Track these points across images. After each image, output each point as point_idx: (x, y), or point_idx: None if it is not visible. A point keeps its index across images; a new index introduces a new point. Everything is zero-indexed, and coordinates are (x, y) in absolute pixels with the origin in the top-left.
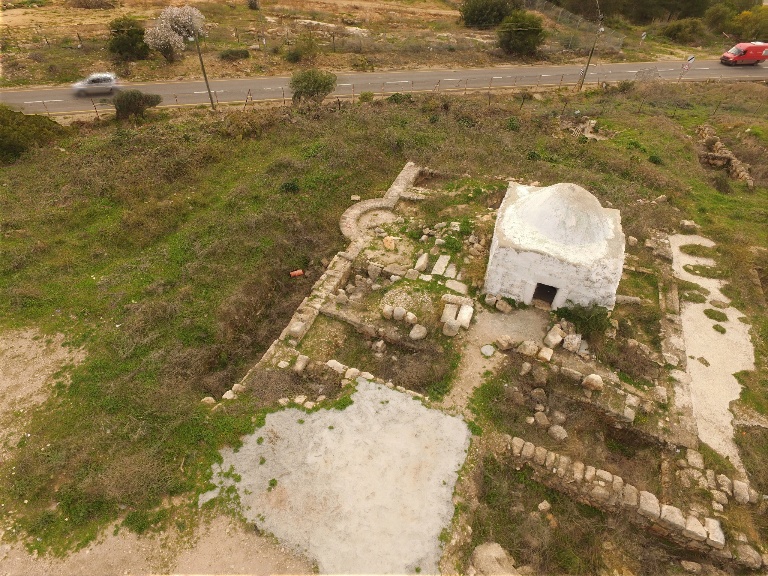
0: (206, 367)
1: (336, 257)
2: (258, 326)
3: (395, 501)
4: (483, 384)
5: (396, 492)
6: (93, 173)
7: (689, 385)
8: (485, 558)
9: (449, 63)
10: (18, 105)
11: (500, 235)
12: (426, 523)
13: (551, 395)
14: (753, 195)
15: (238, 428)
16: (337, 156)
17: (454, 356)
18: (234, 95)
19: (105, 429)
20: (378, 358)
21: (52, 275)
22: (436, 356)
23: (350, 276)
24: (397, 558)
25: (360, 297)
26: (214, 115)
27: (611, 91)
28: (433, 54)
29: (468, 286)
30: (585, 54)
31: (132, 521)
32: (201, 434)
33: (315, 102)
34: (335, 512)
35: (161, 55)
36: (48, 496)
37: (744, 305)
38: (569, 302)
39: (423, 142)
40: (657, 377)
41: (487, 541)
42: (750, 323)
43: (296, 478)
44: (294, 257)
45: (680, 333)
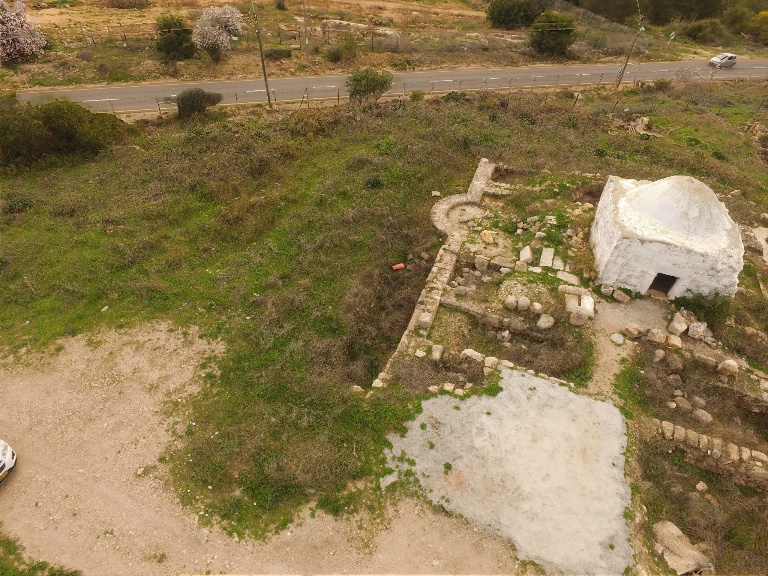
0: None
1: (441, 250)
2: (379, 318)
3: (571, 482)
4: (623, 370)
5: (570, 474)
6: (177, 170)
7: None
8: (667, 535)
9: (484, 62)
10: (85, 103)
11: (621, 226)
12: (607, 502)
13: (688, 381)
14: None
15: (400, 414)
16: (413, 153)
17: (587, 344)
18: (286, 94)
19: (270, 417)
20: (510, 347)
21: (167, 269)
22: None
23: (457, 269)
24: (589, 536)
25: (475, 289)
26: (271, 113)
27: (647, 90)
28: (468, 54)
29: (579, 277)
30: (613, 54)
31: (326, 504)
32: (365, 421)
33: (375, 100)
34: (516, 493)
35: (205, 54)
36: (230, 482)
37: None
38: (689, 291)
39: (489, 139)
40: None
41: (661, 520)
42: None
43: (469, 462)
44: (393, 251)
45: None
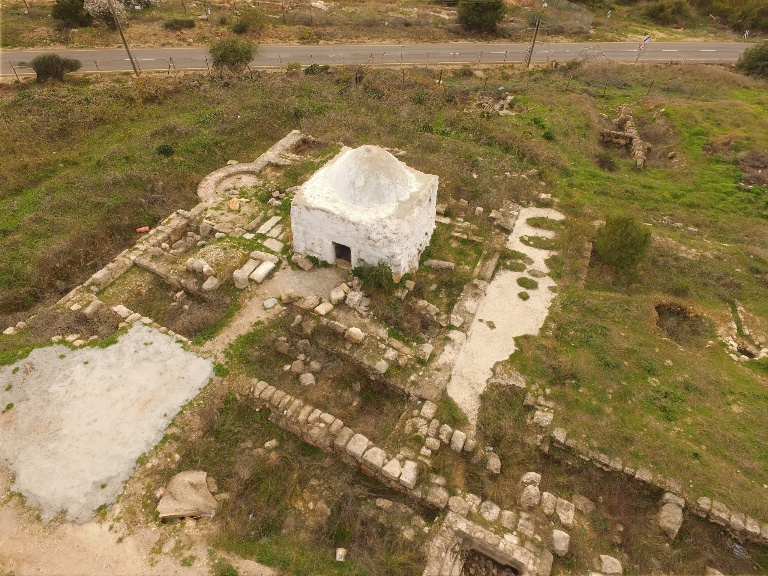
0: (12, 308)
1: (174, 214)
2: (77, 274)
3: (112, 428)
4: (248, 332)
5: (117, 420)
6: None
7: (464, 345)
8: (179, 482)
9: (402, 38)
10: None
11: (299, 194)
12: (130, 448)
13: (313, 346)
14: (640, 174)
15: None
16: (223, 122)
17: (235, 306)
18: (164, 63)
19: None
20: (168, 306)
21: None
22: (223, 306)
23: (184, 233)
24: (89, 475)
25: (180, 251)
26: None
27: (559, 70)
28: (387, 29)
29: (284, 245)
30: (551, 33)
31: None
32: None
33: (229, 70)
34: (53, 434)
35: None
36: None
37: (560, 275)
38: (361, 261)
39: (321, 112)
40: (435, 336)
41: (194, 469)
42: (558, 292)
43: (32, 404)
44: (145, 215)
45: (478, 297)
